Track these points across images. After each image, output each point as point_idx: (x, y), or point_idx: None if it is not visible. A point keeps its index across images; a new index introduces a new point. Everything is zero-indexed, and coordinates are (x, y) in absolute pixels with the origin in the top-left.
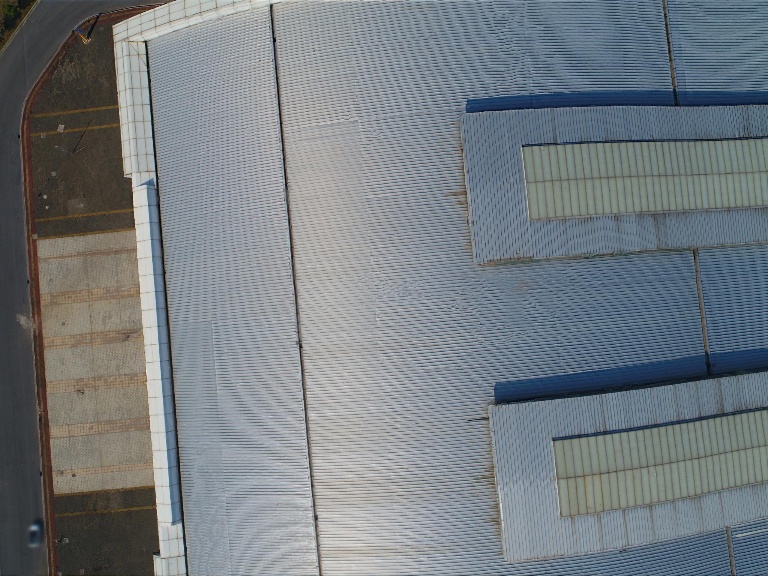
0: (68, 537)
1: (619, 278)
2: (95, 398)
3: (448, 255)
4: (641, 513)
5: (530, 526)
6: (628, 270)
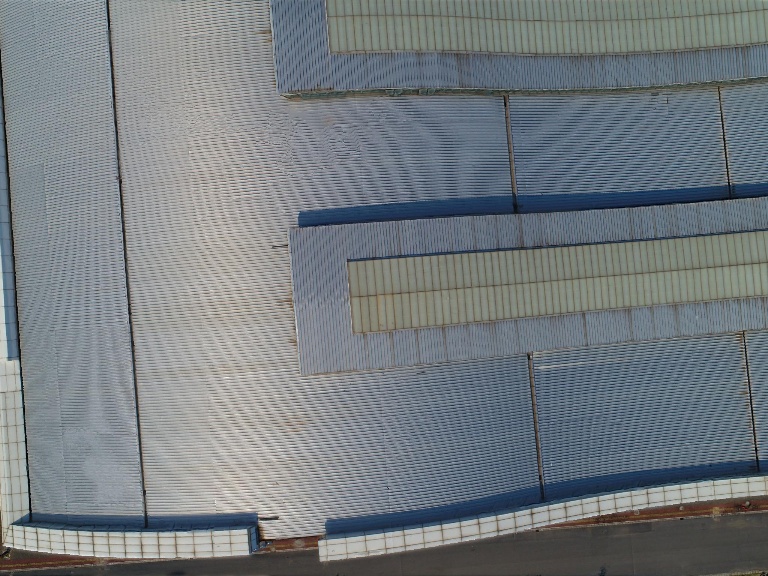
0: None
1: (425, 117)
2: None
3: (257, 90)
4: (433, 333)
5: (324, 342)
6: (434, 110)
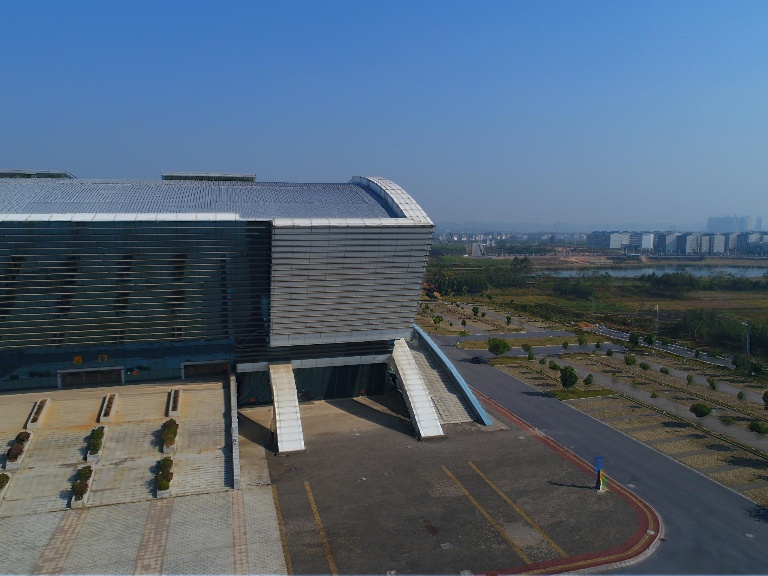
0: (384, 572)
1: None
2: (80, 569)
3: None
4: None
5: None
6: None
